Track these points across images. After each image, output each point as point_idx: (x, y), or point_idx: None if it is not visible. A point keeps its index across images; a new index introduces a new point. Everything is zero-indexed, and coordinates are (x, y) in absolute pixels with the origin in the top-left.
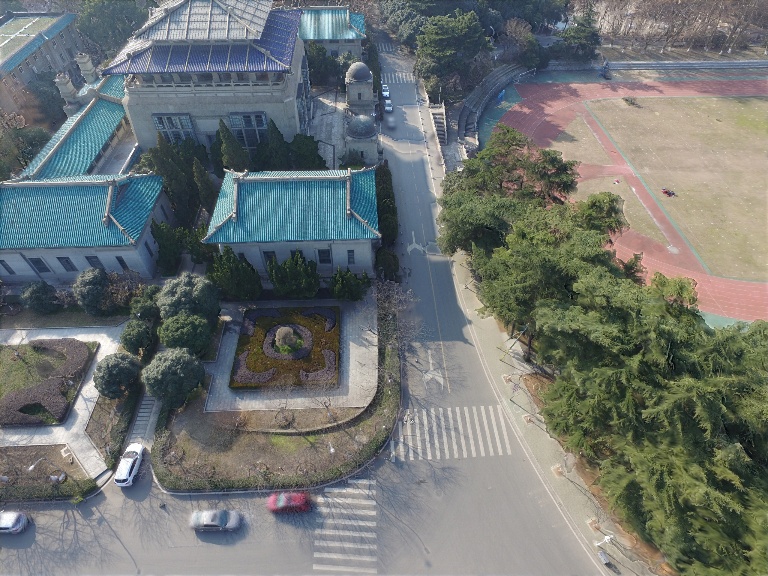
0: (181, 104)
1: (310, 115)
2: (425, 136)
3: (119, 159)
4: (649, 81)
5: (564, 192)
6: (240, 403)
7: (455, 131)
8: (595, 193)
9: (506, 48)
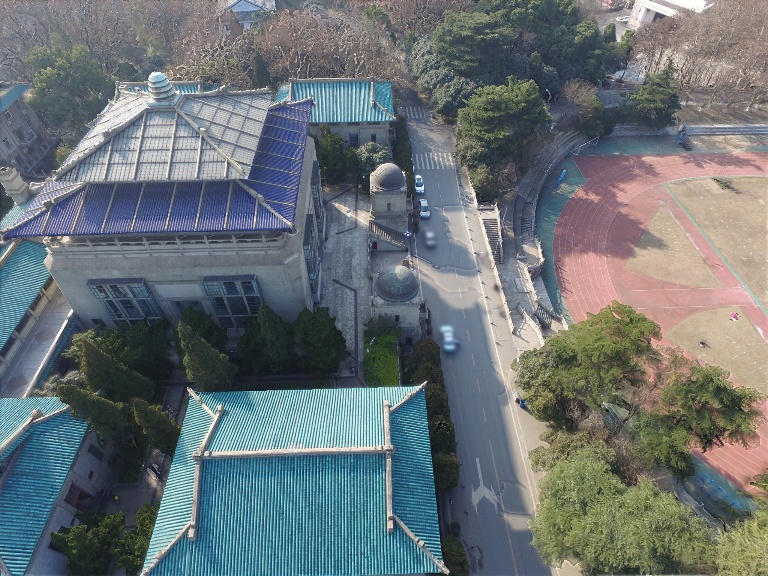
0: (130, 268)
1: (322, 237)
2: (477, 261)
3: (42, 340)
4: (740, 152)
5: (737, 443)
6: None
7: (511, 239)
8: (708, 337)
9: (564, 114)
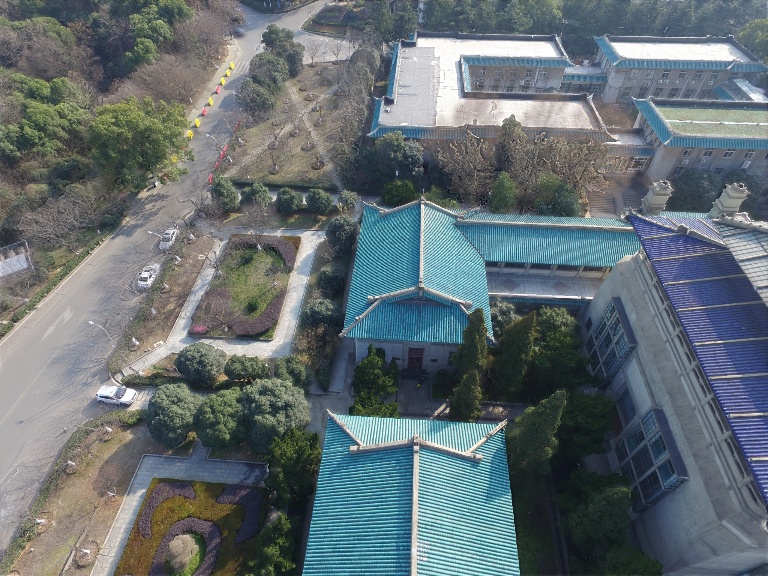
0: (643, 327)
1: None
2: None
3: (555, 287)
4: None
5: None
6: (136, 494)
7: None
8: None
9: None
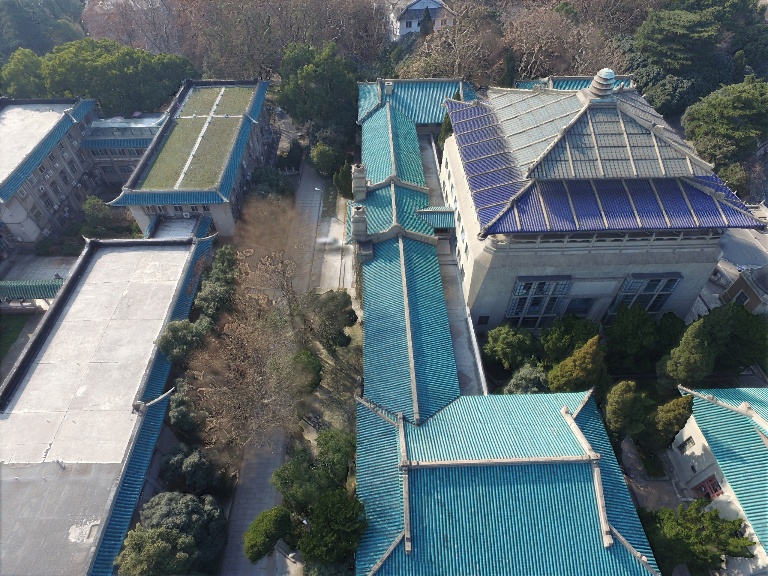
0: (567, 265)
1: None
2: None
3: (455, 337)
4: None
5: None
6: None
7: None
8: None
9: None
